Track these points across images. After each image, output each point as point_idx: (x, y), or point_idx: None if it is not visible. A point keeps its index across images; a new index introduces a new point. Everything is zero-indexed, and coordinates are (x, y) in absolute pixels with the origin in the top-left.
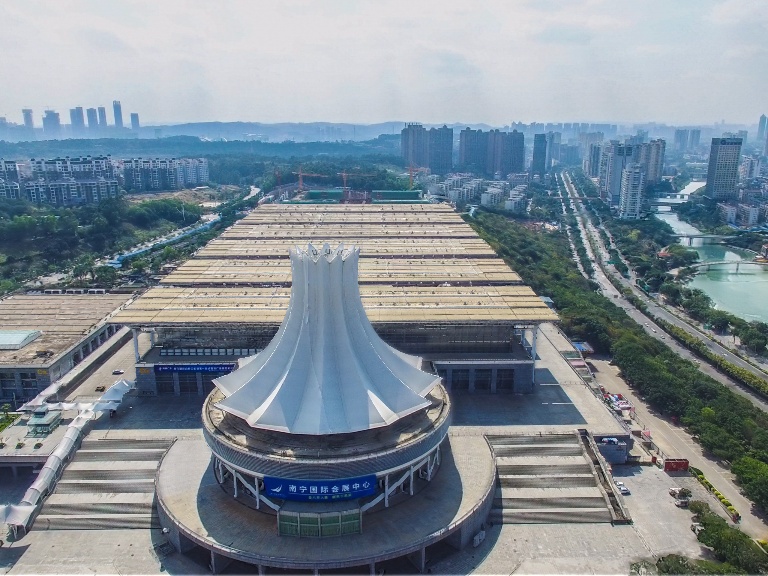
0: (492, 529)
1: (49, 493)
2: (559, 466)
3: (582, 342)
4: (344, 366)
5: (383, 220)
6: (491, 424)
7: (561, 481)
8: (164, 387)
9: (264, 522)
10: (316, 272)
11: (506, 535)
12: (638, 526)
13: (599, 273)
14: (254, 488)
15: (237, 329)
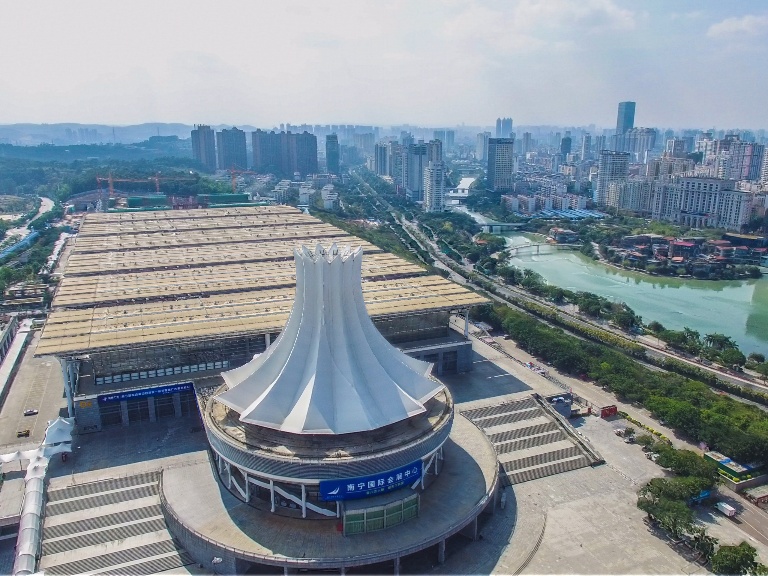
0: (506, 491)
1: (39, 556)
2: (531, 428)
3: (479, 322)
4: (365, 362)
5: (240, 224)
6: (458, 402)
7: (538, 440)
8: (106, 419)
9: (320, 528)
10: (330, 273)
11: (520, 493)
12: (611, 464)
13: (437, 262)
14: (298, 497)
15: (185, 345)
